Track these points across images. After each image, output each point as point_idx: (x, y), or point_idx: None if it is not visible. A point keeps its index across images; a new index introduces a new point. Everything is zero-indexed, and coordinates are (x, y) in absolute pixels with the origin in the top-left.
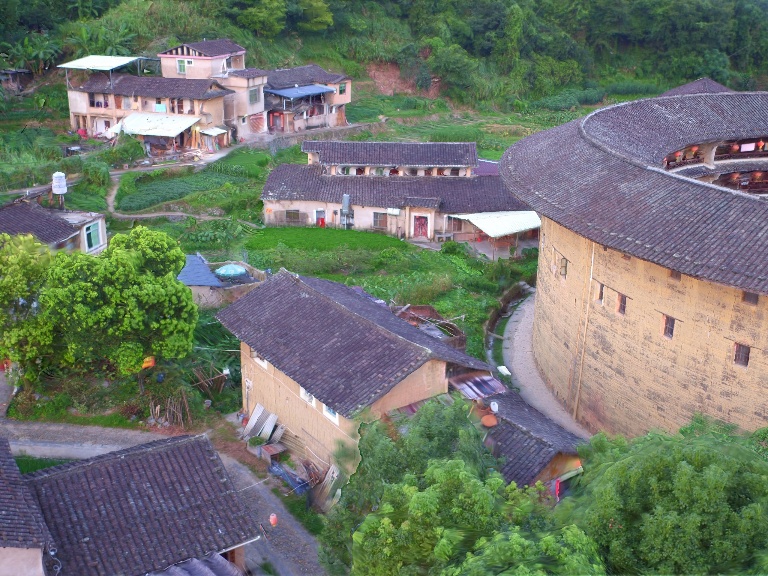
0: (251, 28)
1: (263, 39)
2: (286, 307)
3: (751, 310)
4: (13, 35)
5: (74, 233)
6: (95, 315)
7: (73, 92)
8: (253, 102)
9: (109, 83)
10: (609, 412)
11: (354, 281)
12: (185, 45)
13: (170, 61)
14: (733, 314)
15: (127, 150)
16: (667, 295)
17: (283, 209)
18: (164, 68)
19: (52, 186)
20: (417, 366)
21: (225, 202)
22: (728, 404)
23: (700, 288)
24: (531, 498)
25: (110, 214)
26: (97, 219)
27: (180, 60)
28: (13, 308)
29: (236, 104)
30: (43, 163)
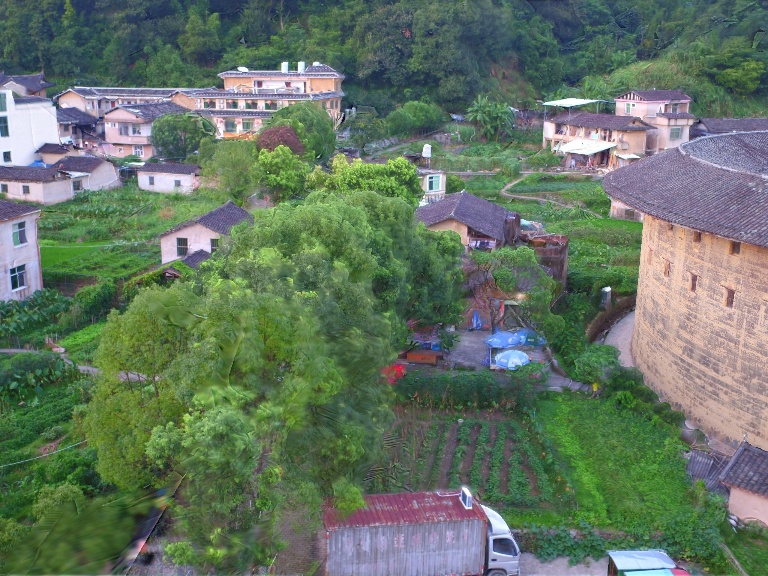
0: (726, 86)
1: (738, 96)
2: (443, 204)
3: (653, 225)
4: (554, 88)
5: (418, 177)
6: (351, 191)
7: (547, 123)
8: (674, 138)
9: (569, 117)
10: None
11: (608, 247)
12: (632, 92)
13: (621, 104)
14: None
15: (545, 159)
16: None
17: (624, 207)
18: (617, 109)
19: (423, 152)
20: (442, 220)
21: (588, 198)
22: None
23: None
24: (477, 303)
25: (499, 192)
26: (438, 173)
27: (628, 103)
28: (334, 190)
29: (659, 139)
30: (478, 158)
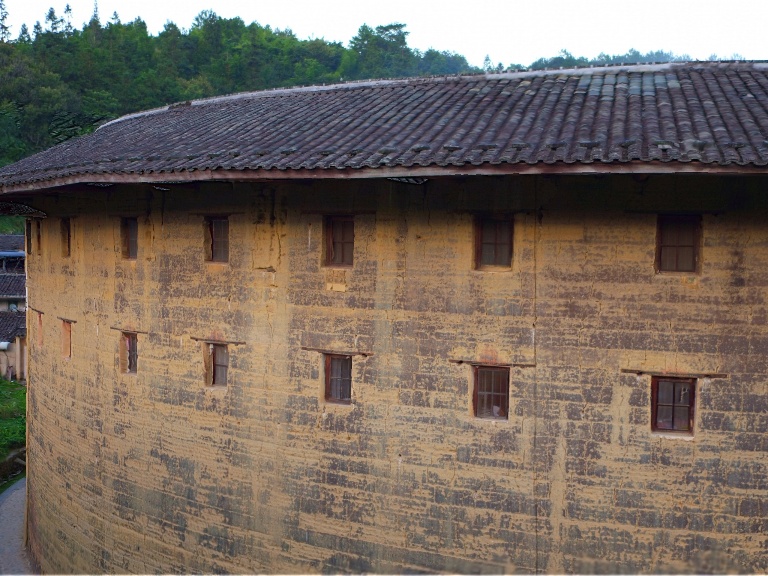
0: None
1: None
2: None
3: (131, 267)
4: None
5: None
6: None
7: None
8: None
9: None
10: (37, 516)
11: None
12: None
13: None
14: (115, 283)
15: None
16: (62, 286)
17: None
18: None
19: None
20: None
21: None
22: (123, 447)
23: (85, 255)
24: None
25: None
26: None
27: None
28: None
29: None
30: None
